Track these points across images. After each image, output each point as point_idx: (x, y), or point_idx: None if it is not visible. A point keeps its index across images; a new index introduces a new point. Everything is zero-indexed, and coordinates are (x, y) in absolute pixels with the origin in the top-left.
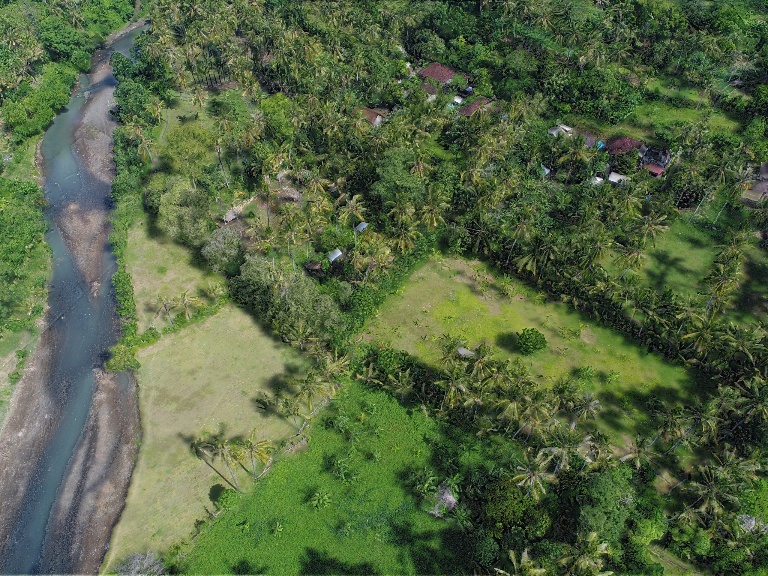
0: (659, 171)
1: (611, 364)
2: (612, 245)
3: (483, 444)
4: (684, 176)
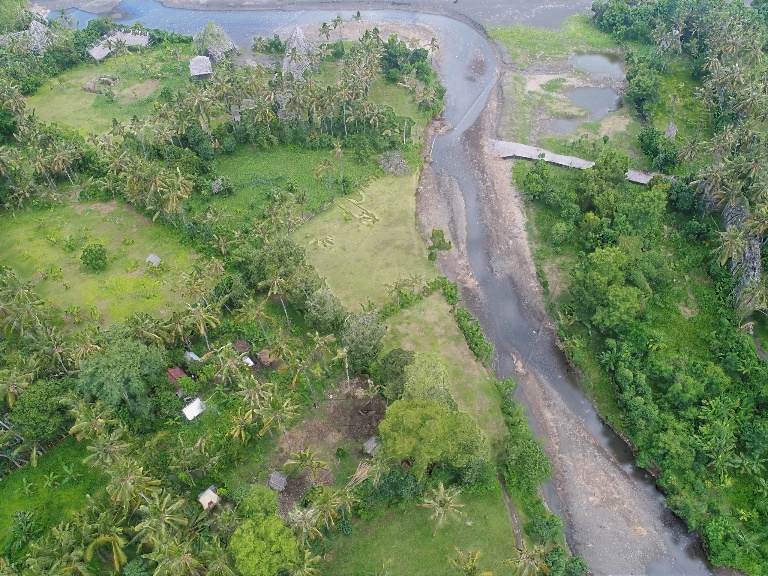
0: None
1: (41, 254)
2: None
3: None
4: None
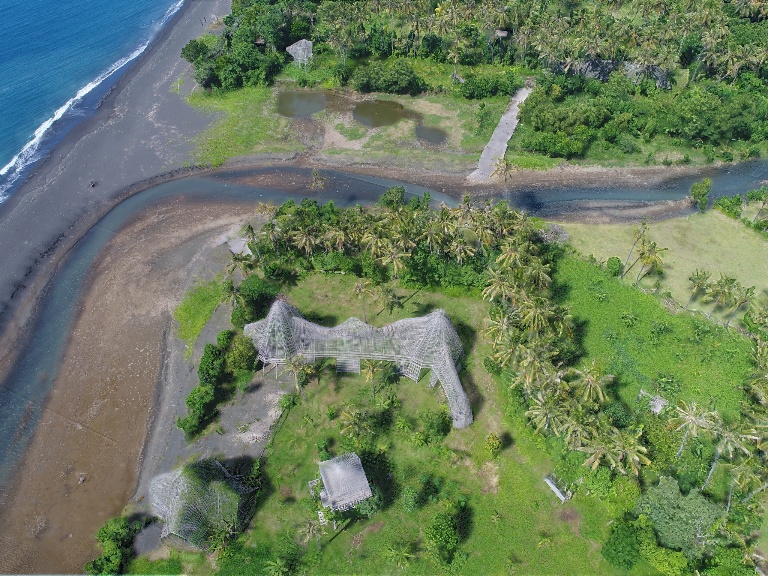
0: None
1: None
2: None
3: None
4: None
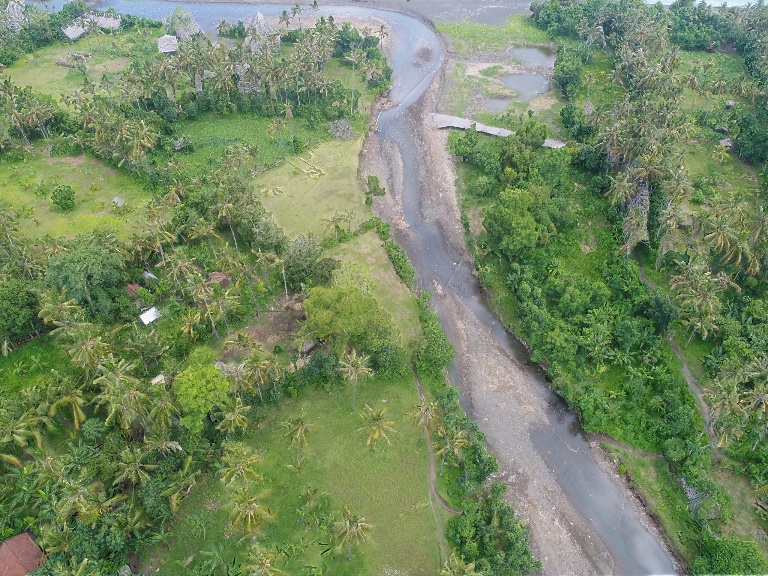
0: None
1: (14, 197)
2: None
3: None
4: None
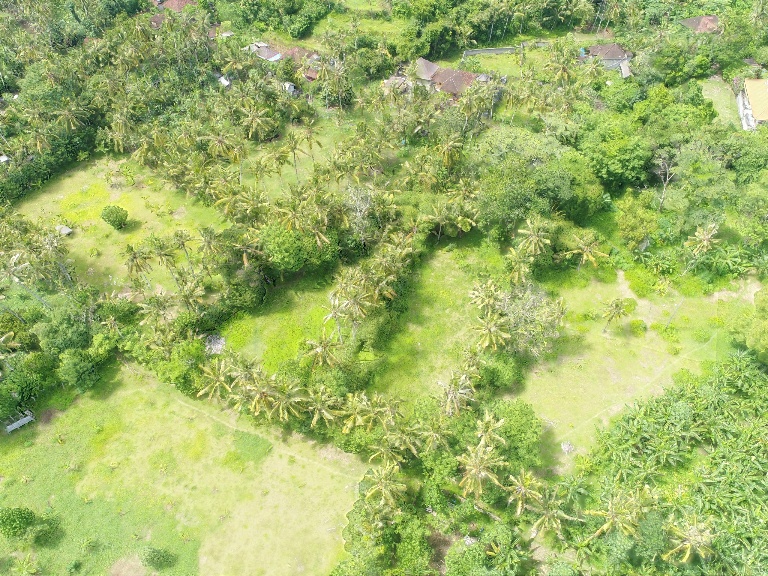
0: (315, 76)
1: None
2: (249, 141)
3: (39, 295)
4: (297, 74)
